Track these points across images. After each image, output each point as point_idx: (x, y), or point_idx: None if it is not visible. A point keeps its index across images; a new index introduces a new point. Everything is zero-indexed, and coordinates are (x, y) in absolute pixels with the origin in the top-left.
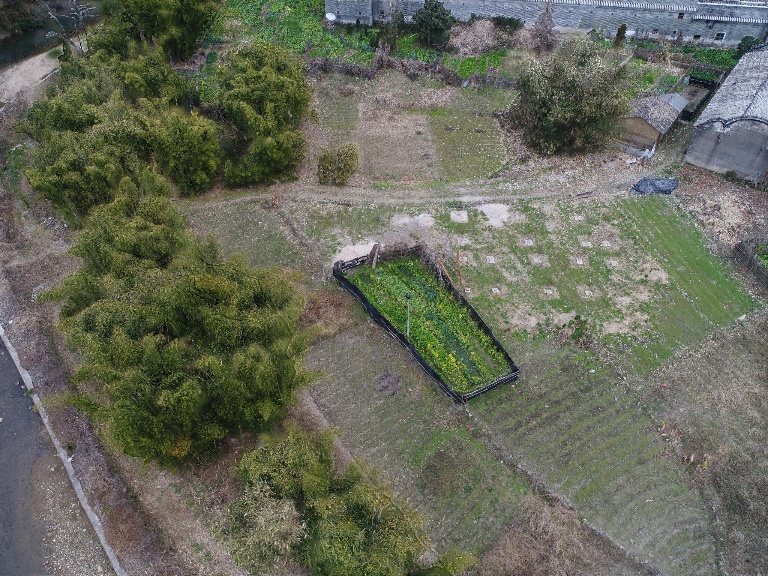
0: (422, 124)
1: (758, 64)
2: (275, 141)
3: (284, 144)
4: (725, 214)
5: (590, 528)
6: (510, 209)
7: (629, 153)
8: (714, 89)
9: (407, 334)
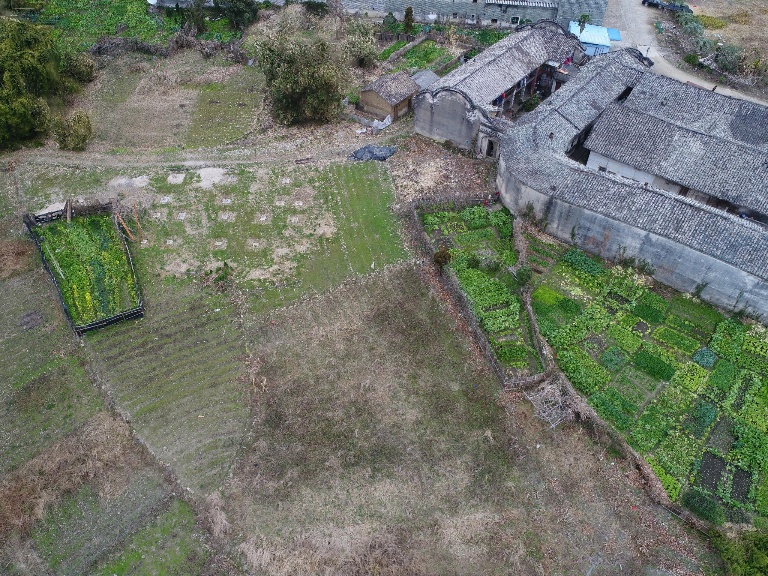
0: (191, 98)
1: (508, 43)
2: (9, 108)
3: (16, 110)
4: (422, 178)
5: (136, 438)
6: (227, 172)
7: (363, 124)
8: None
9: (62, 277)
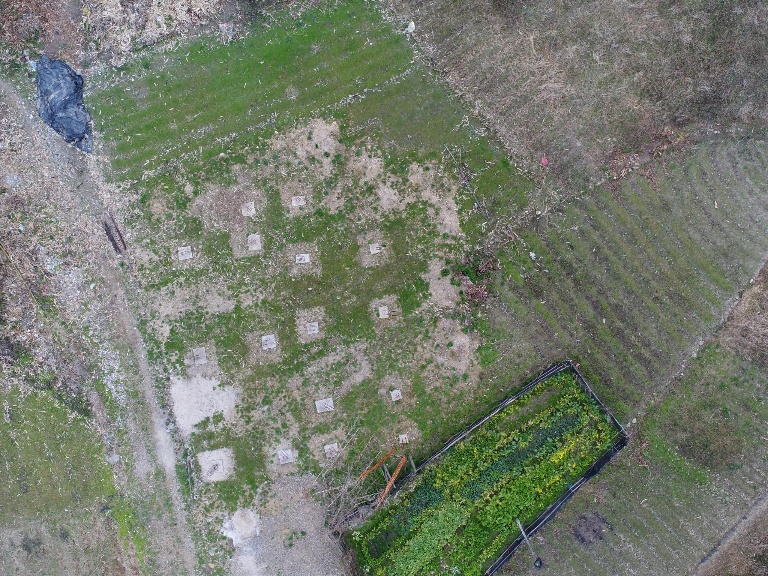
0: None
1: None
2: None
3: None
4: None
5: None
6: (181, 375)
7: None
8: None
9: None
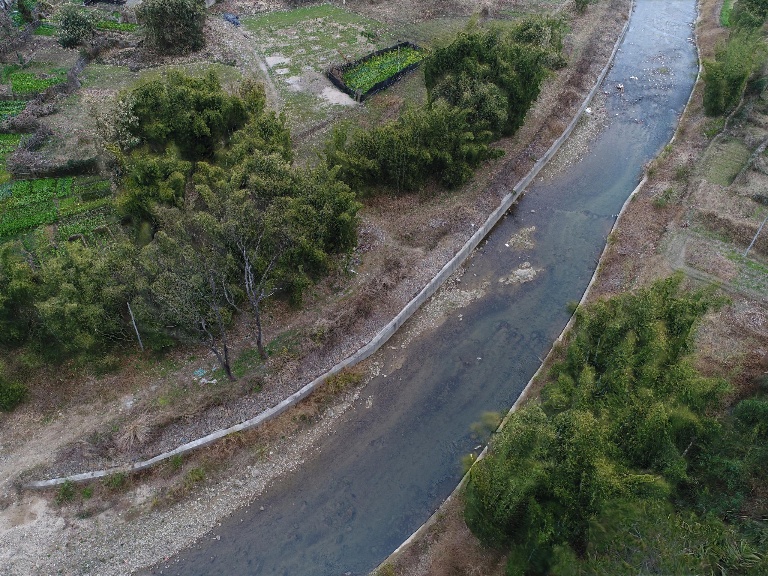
0: None
1: None
2: None
3: None
4: None
5: None
6: None
7: None
8: (98, 0)
9: None
